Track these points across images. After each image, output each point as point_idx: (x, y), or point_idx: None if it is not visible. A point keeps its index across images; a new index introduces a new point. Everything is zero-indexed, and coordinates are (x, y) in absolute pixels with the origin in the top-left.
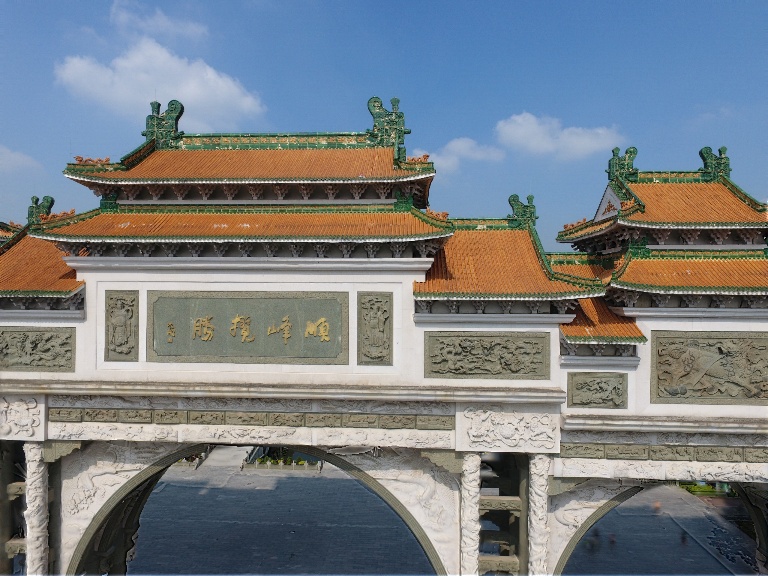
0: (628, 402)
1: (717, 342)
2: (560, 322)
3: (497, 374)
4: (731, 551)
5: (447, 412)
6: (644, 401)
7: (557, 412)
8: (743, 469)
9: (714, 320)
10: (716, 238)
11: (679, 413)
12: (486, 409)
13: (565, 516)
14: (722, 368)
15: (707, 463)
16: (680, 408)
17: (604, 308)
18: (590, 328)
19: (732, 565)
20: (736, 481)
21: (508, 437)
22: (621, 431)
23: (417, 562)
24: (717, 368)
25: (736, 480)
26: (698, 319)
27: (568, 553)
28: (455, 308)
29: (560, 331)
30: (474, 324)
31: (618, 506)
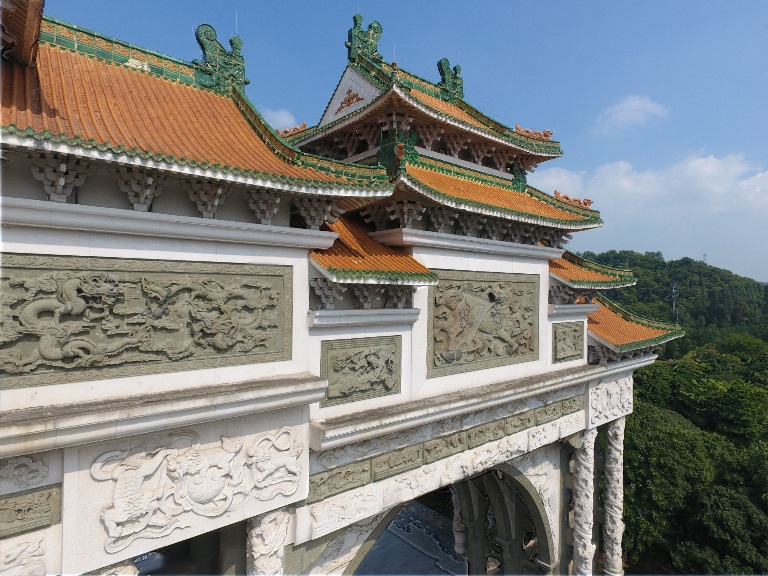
0: (402, 382)
1: (488, 286)
2: (312, 246)
3: (182, 359)
4: (405, 521)
5: (34, 480)
6: (420, 377)
7: (304, 420)
8: (505, 446)
9: (486, 257)
10: (476, 156)
11: (455, 387)
12: (154, 447)
13: None
14: (492, 320)
15: (477, 449)
16: (456, 380)
17: (363, 235)
18: (358, 260)
19: (410, 536)
20: (500, 463)
21: (208, 499)
22: (399, 431)
23: None
24: (488, 320)
25: (500, 462)
26: (473, 254)
27: None
28: (65, 191)
29: (310, 264)
30: (123, 239)
31: None
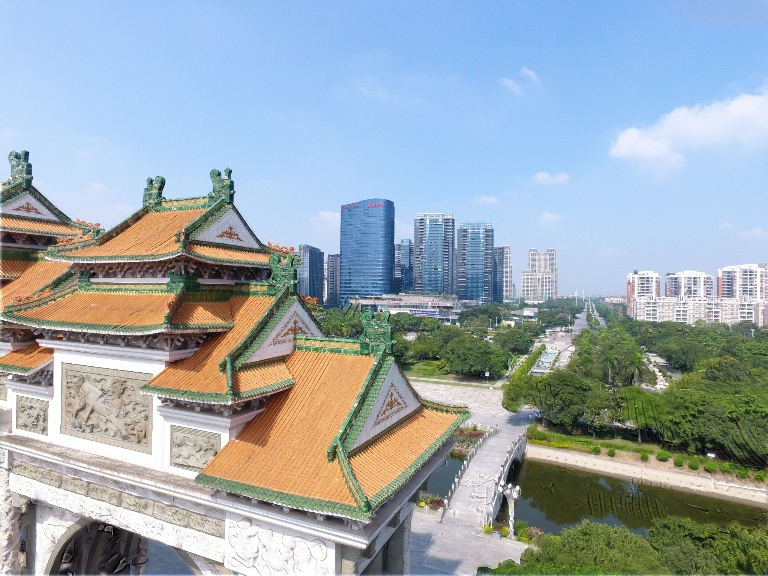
0: (48, 429)
1: (102, 379)
2: (8, 349)
3: None
4: None
5: None
6: (56, 430)
7: (7, 431)
8: (117, 514)
9: (100, 356)
10: None
11: (77, 446)
12: None
13: (48, 530)
14: (103, 406)
15: (95, 501)
16: (77, 441)
17: None
18: (22, 356)
19: None
20: (113, 525)
21: None
22: None
23: (171, 561)
24: (99, 405)
25: (112, 524)
26: (90, 354)
27: (51, 565)
28: None
29: None
30: None
31: (434, 556)
